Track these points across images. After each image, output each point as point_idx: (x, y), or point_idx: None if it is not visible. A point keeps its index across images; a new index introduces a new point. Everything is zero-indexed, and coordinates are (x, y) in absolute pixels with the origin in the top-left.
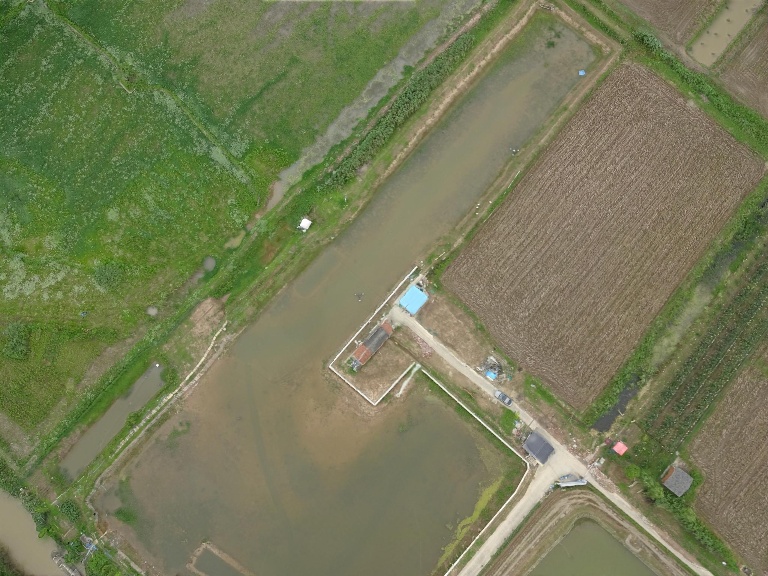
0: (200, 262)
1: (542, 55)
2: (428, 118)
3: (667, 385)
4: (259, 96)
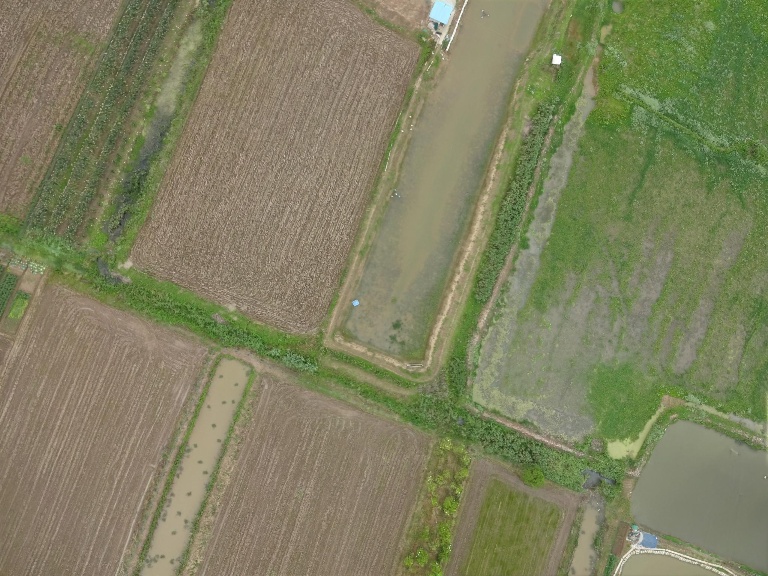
0: (626, 5)
1: (402, 310)
2: (488, 200)
3: (180, 4)
4: (643, 171)
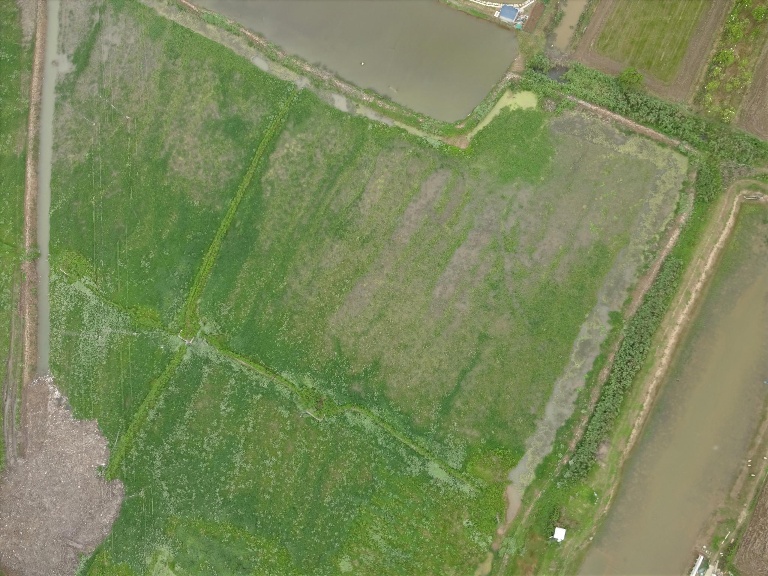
0: None
1: (765, 257)
2: (656, 369)
3: None
4: (458, 390)
